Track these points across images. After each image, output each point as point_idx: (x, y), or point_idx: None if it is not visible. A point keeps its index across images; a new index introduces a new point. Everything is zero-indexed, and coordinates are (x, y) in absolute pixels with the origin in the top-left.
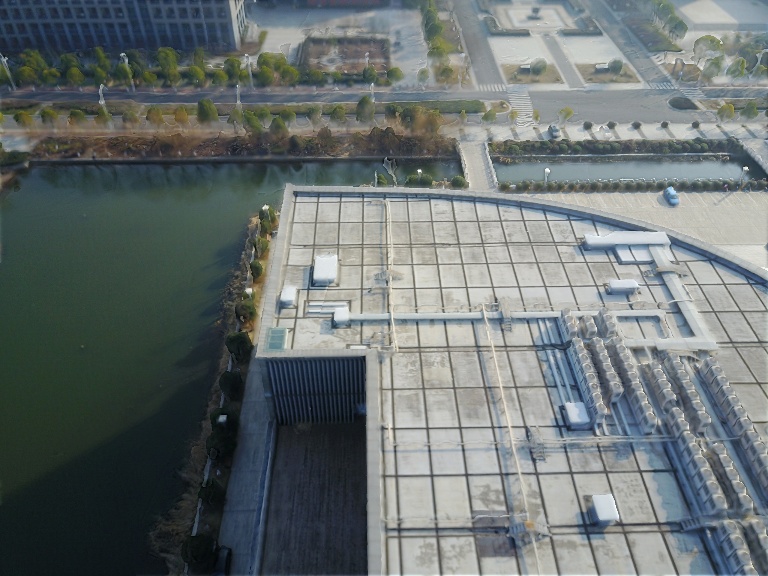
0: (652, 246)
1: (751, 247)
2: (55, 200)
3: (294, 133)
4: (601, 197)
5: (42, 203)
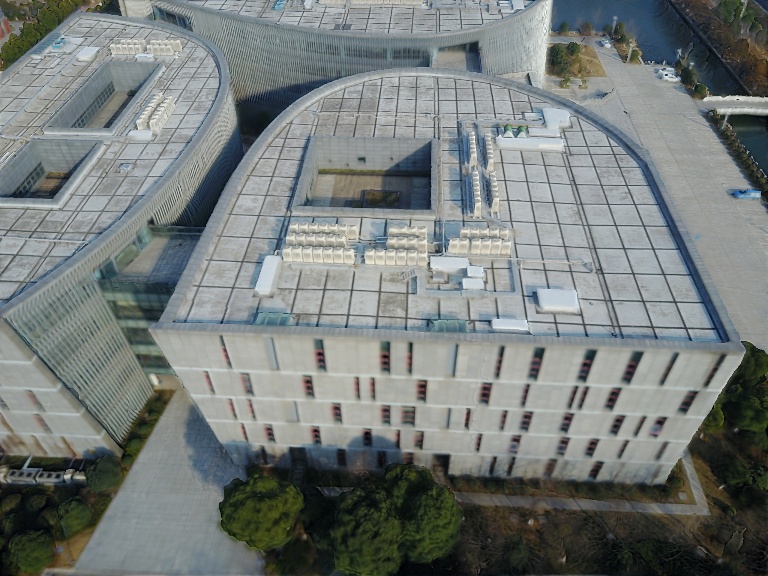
0: (511, 6)
1: None
2: (637, 5)
3: None
4: None
5: (632, 2)
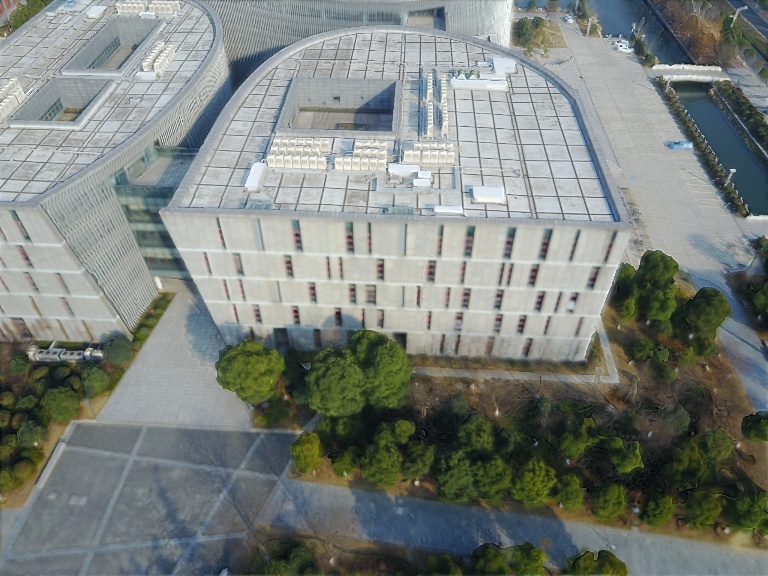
0: None
1: (614, 164)
2: None
3: (699, 21)
4: (666, 117)
5: None
